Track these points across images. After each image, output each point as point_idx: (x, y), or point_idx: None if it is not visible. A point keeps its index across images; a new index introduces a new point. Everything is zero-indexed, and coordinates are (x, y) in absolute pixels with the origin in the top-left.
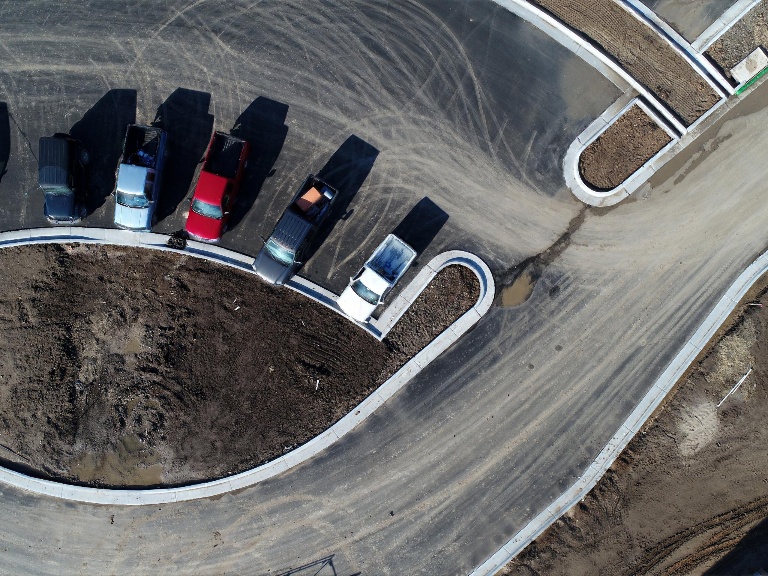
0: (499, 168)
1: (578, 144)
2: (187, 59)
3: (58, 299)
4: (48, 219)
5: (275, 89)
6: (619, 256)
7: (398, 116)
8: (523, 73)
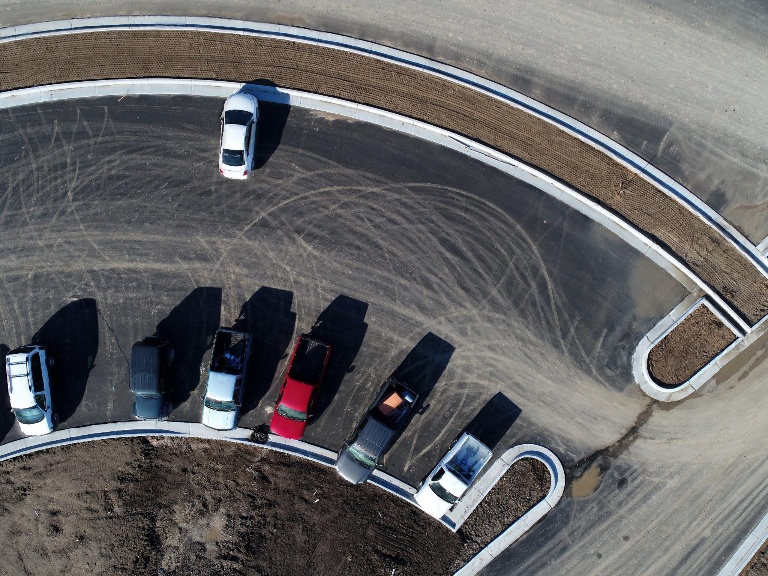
0: (570, 364)
1: (647, 342)
2: (271, 258)
3: (143, 490)
4: (136, 417)
5: (355, 288)
6: (685, 449)
7: (474, 314)
8: (594, 273)
